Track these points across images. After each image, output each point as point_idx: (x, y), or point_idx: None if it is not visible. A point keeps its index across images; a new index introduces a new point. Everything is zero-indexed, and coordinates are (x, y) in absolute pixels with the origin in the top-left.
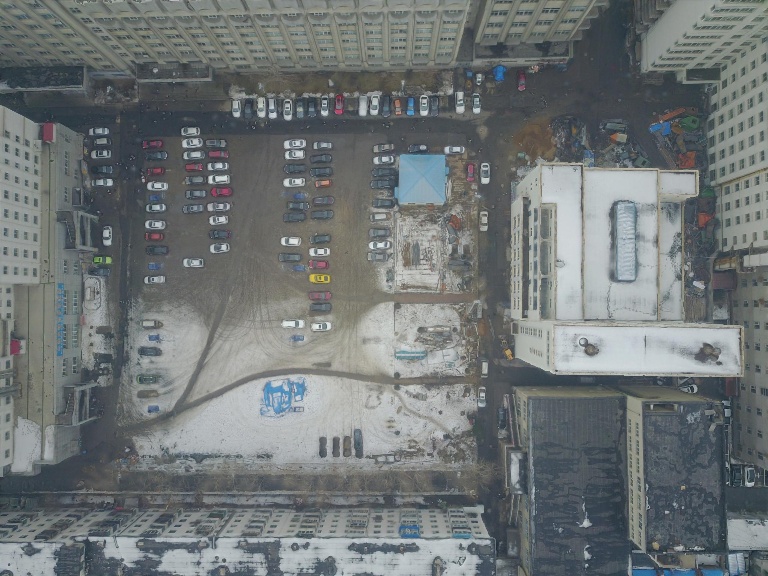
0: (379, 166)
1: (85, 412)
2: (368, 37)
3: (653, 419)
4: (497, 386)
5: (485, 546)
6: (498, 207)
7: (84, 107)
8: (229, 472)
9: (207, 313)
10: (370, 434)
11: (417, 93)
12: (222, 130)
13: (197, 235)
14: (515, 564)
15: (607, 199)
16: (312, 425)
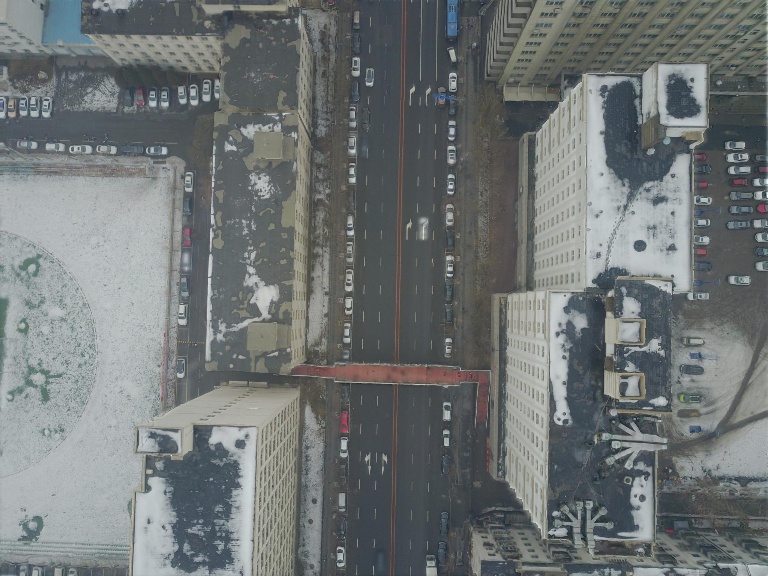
0: None
1: None
2: None
3: None
4: None
5: None
6: None
7: None
8: None
9: (751, 332)
10: None
11: None
12: (767, 145)
13: (740, 252)
14: None
15: None
16: None
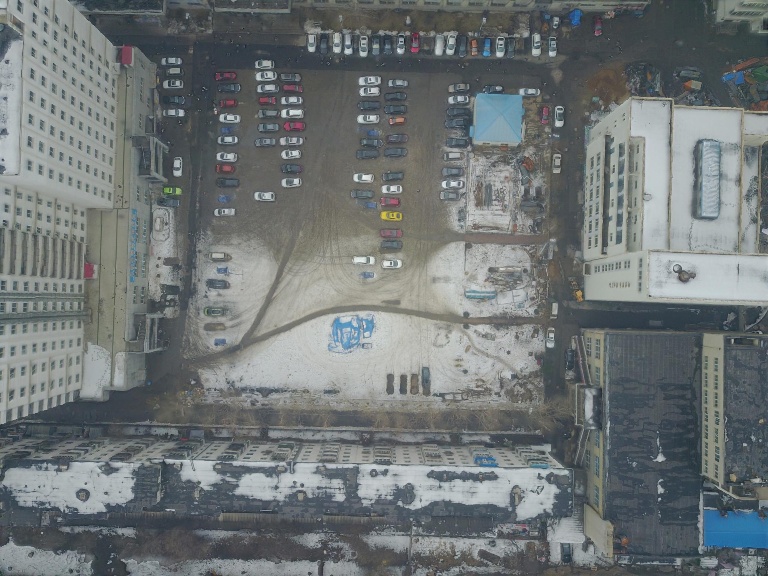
0: (454, 106)
1: (154, 341)
2: None
3: (733, 353)
4: (565, 328)
5: (563, 476)
6: (571, 150)
7: (156, 37)
8: (295, 407)
9: (277, 247)
10: (438, 372)
11: (493, 34)
12: (297, 64)
13: (269, 169)
14: (581, 502)
15: (692, 137)
16: (380, 362)
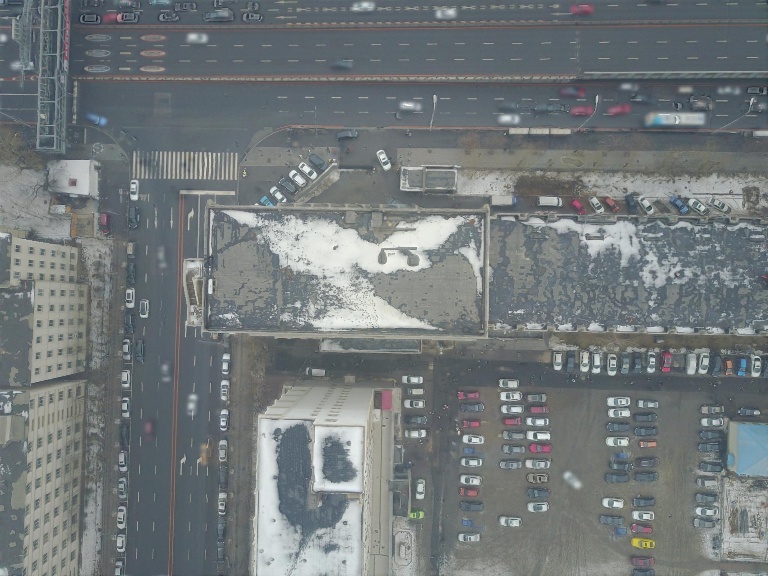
0: (706, 427)
1: None
2: None
3: None
4: None
5: None
6: None
7: None
8: None
9: (523, 573)
10: None
11: None
12: (541, 382)
13: (513, 491)
14: None
15: None
16: None
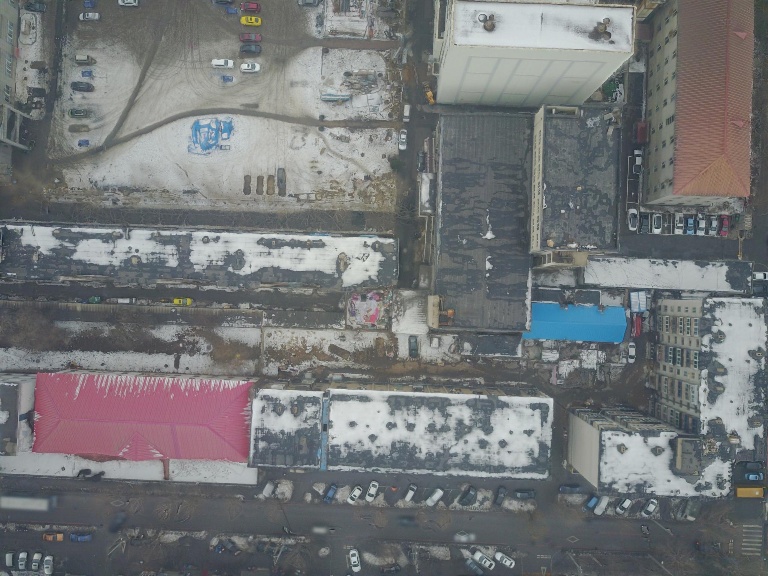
0: None
1: (15, 135)
2: None
3: (554, 122)
4: (418, 131)
5: (388, 244)
6: None
7: None
8: (155, 206)
9: (140, 52)
10: (293, 174)
11: None
12: None
13: None
14: (425, 294)
15: None
16: (238, 163)
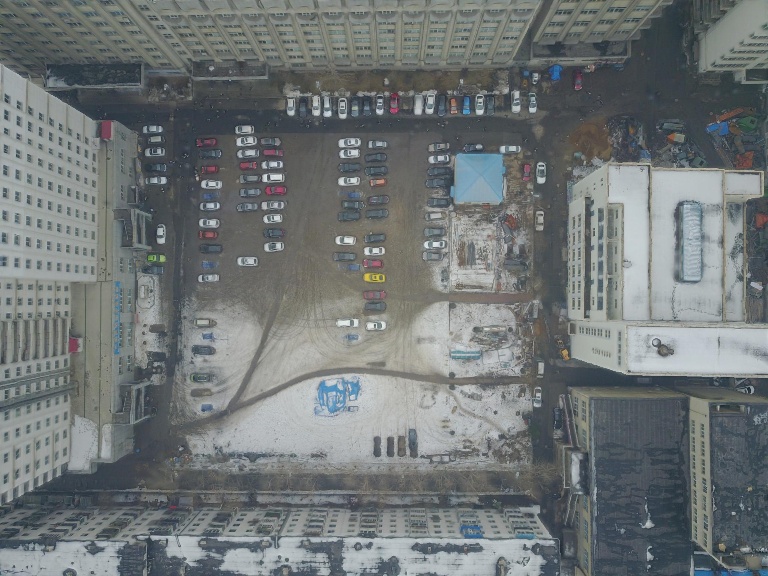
0: (434, 165)
1: (140, 410)
2: (431, 36)
3: (720, 420)
4: (552, 386)
5: (549, 547)
6: (554, 207)
7: (137, 105)
8: (283, 471)
9: (261, 312)
10: (425, 434)
11: (472, 92)
12: (276, 128)
13: (251, 234)
14: (572, 565)
15: (672, 199)
16: (366, 424)
